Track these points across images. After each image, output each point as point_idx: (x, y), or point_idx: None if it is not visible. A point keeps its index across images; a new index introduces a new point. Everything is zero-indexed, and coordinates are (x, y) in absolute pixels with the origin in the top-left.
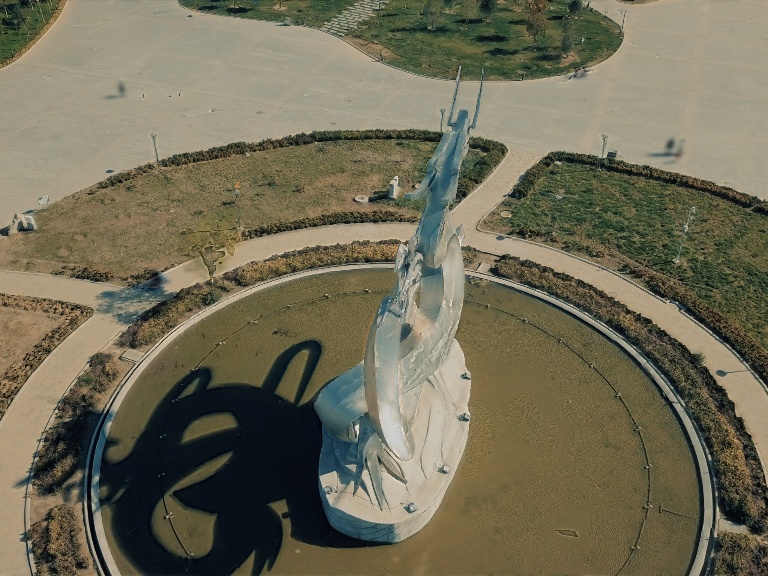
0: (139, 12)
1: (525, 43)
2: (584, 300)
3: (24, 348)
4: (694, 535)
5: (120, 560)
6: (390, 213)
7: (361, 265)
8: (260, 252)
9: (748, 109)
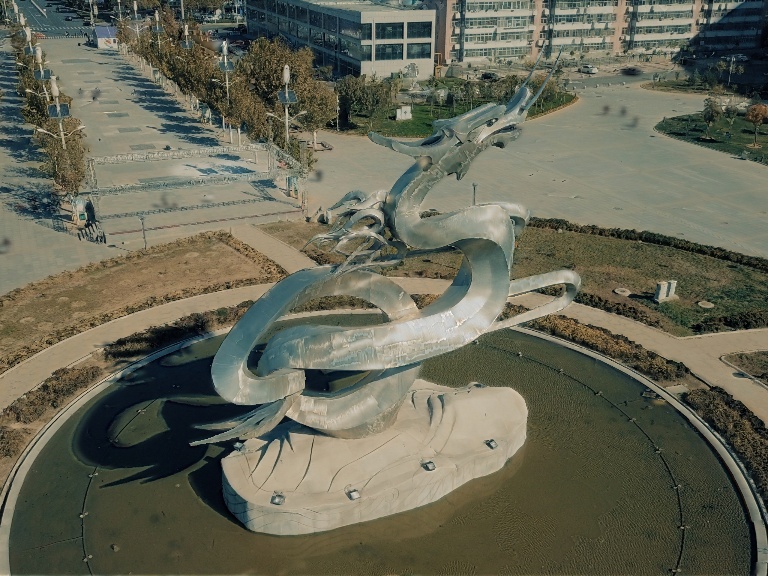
0: (610, 126)
1: None
2: (763, 465)
3: (219, 281)
4: None
5: (78, 417)
6: (634, 310)
7: (542, 334)
8: None
9: None
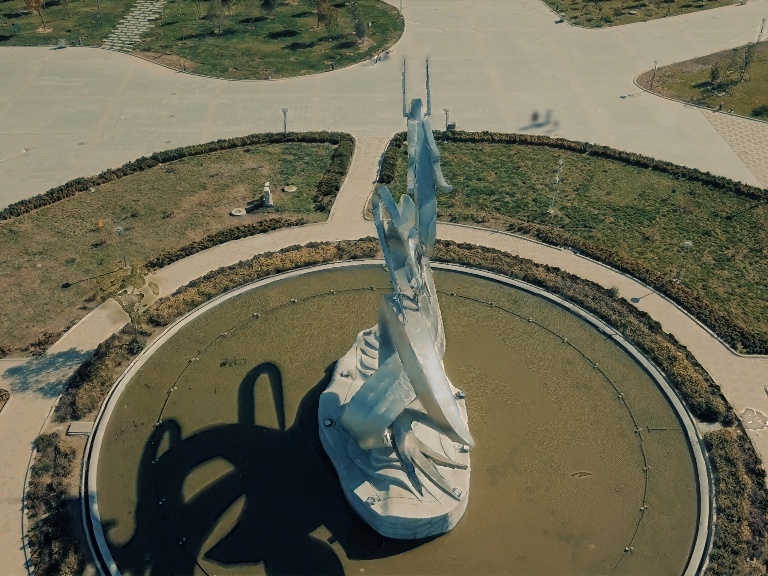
0: None
1: (317, 34)
2: (495, 263)
3: None
4: (685, 443)
5: None
6: (275, 220)
7: (274, 277)
8: (162, 287)
9: (540, 67)
